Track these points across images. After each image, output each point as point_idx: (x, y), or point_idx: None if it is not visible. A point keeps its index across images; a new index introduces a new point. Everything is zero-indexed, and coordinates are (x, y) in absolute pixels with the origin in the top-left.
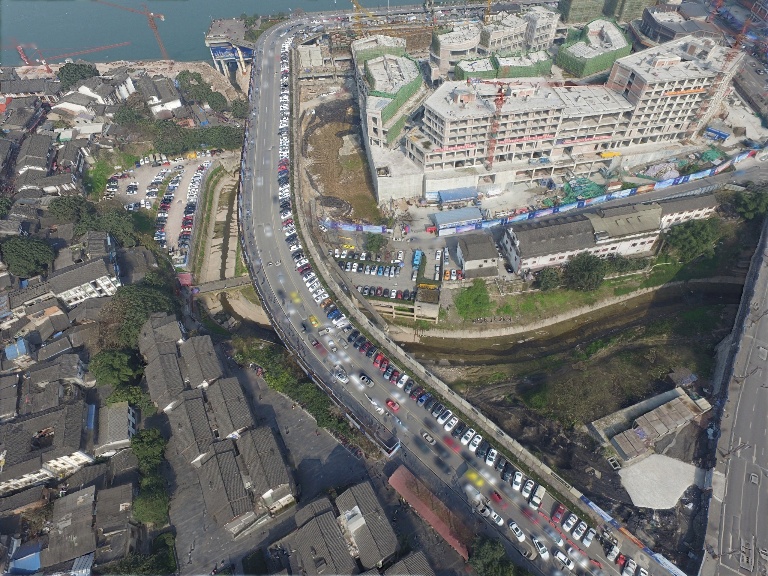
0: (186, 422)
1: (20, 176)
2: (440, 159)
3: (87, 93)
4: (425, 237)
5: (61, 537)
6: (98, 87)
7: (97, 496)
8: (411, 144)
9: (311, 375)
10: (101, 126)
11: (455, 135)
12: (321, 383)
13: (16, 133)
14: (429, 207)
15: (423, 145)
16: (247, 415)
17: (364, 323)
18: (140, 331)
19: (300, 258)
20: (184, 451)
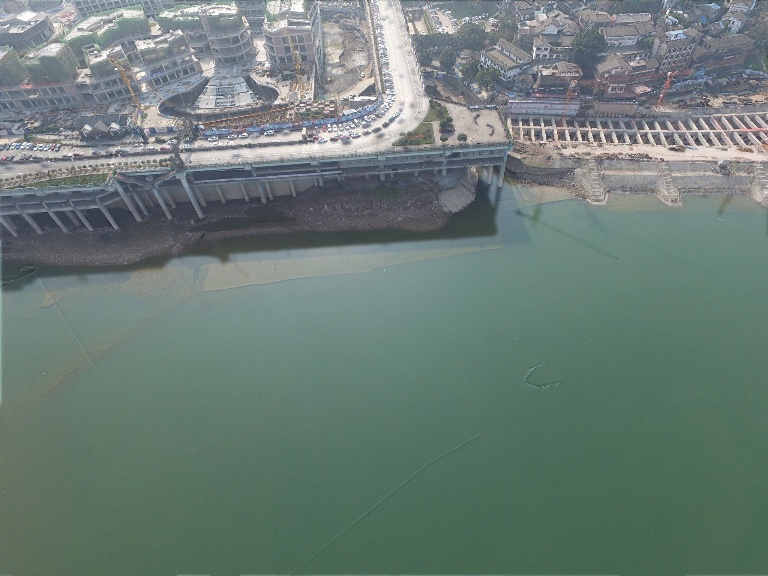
0: None
1: None
2: None
3: None
4: None
5: None
6: None
7: None
8: None
9: None
10: None
11: None
12: None
13: None
14: None
15: None
16: None
17: None
18: None
19: None
20: None
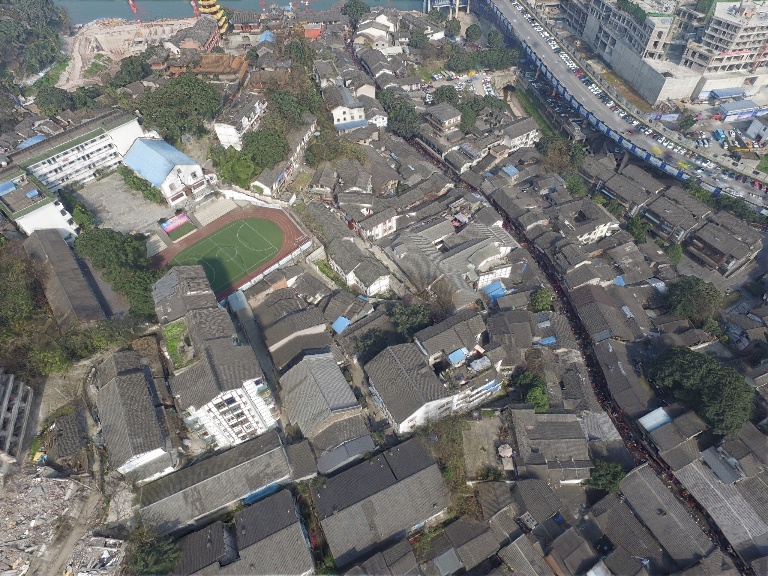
0: (672, 207)
1: (376, 78)
2: (720, 63)
3: (382, 21)
4: (713, 123)
5: (629, 268)
6: (389, 17)
7: (638, 247)
8: (693, 52)
9: (720, 190)
10: (400, 48)
11: (742, 40)
12: (732, 194)
13: (340, 51)
14: (702, 104)
15: (707, 51)
16: (706, 205)
17: (727, 165)
18: (582, 164)
19: (645, 129)
20: (679, 223)
